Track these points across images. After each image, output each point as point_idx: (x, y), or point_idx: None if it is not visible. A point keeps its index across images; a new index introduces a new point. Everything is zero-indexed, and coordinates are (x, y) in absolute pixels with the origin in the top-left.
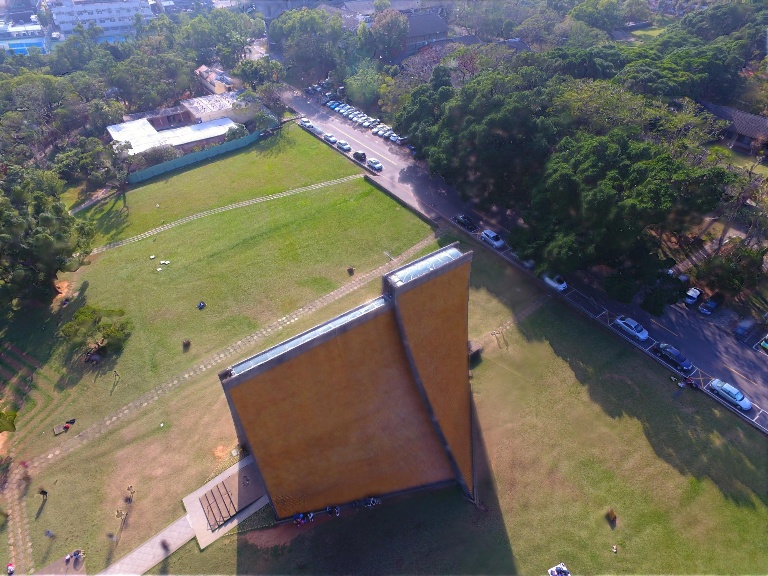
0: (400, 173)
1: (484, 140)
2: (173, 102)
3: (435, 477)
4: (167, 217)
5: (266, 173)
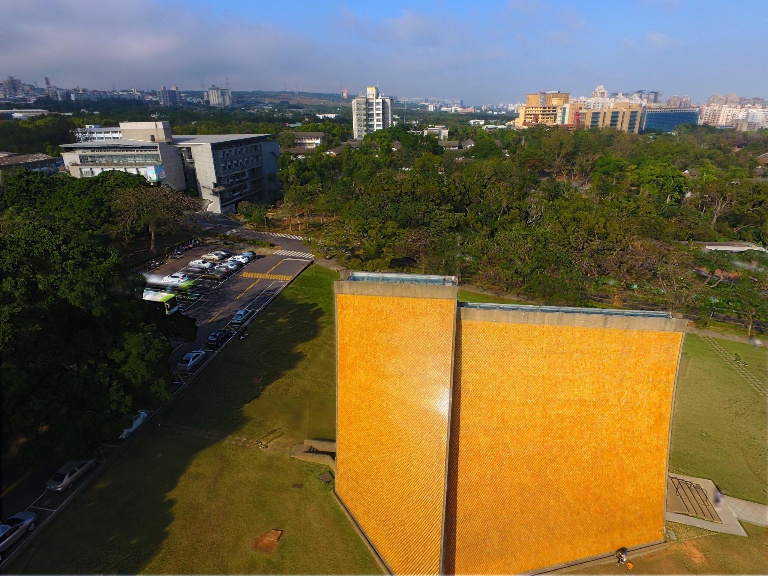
0: None
1: None
2: None
3: None
4: None
5: None
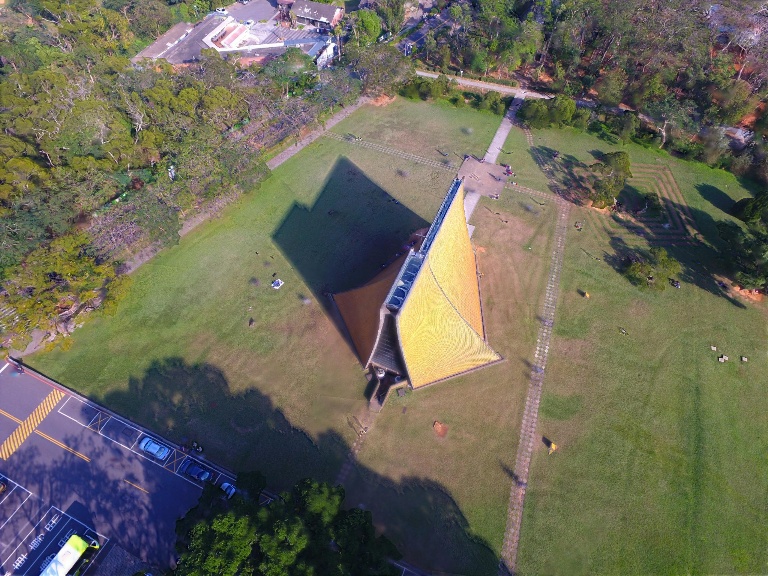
0: None
1: None
2: None
3: None
4: None
5: None
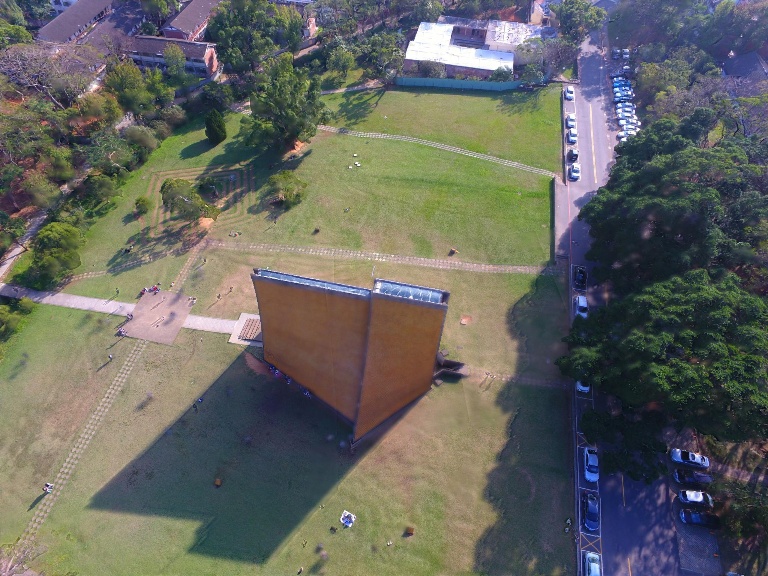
0: (587, 194)
1: (634, 219)
2: (490, 15)
3: (347, 414)
4: (390, 128)
5: (487, 127)
